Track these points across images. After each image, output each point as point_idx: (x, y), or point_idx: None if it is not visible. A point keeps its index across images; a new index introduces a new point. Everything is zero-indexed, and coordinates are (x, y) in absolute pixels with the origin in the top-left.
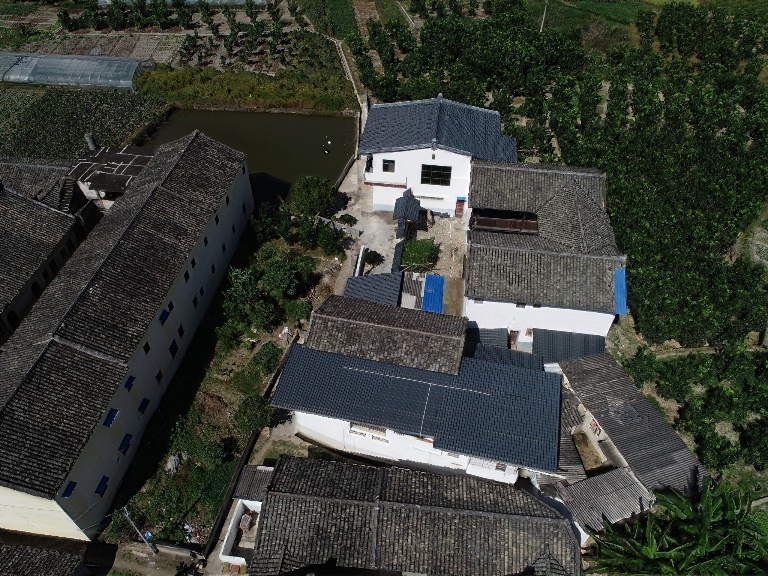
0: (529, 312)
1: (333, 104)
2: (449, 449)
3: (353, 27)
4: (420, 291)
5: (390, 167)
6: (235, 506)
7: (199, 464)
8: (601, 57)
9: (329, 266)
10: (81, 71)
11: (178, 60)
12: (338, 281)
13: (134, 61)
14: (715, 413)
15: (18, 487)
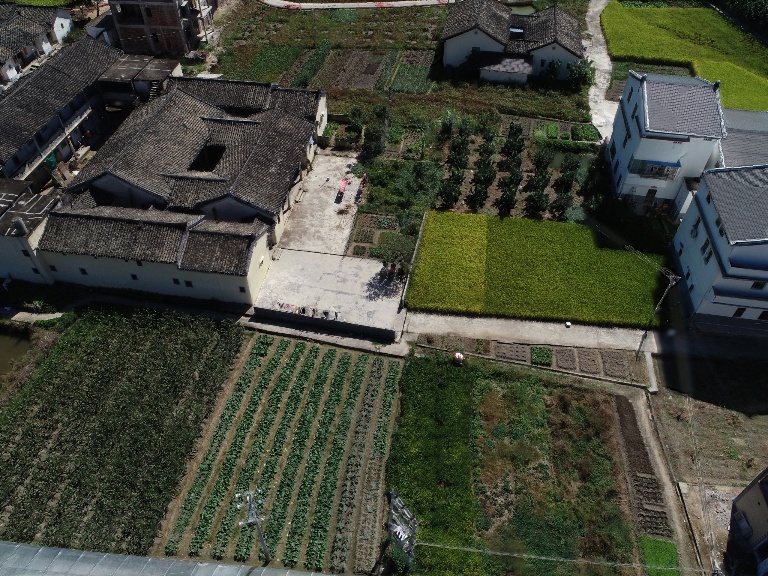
0: None
1: None
2: None
3: None
4: None
5: None
6: None
7: None
8: None
9: None
10: (74, 573)
11: None
12: None
13: None
14: None
15: None
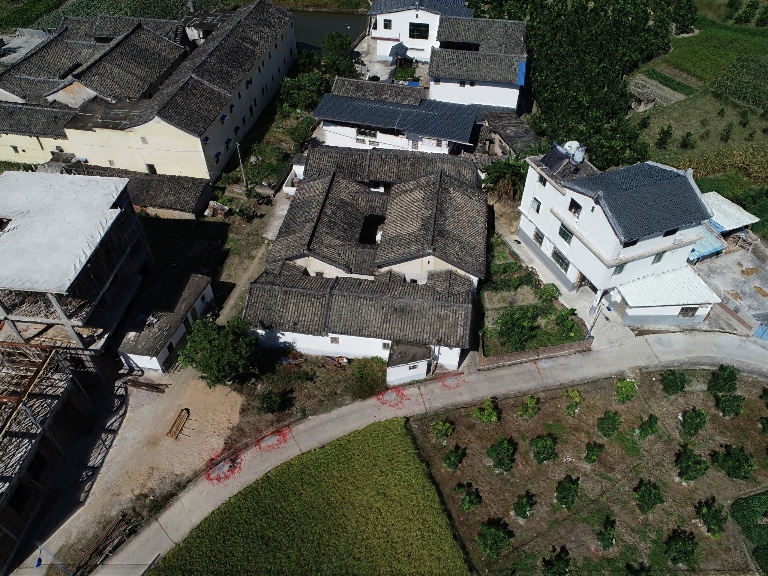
0: (468, 90)
1: (352, 5)
2: (410, 133)
3: None
4: None
5: (388, 25)
6: None
7: None
8: None
9: None
10: None
11: None
12: None
13: None
14: (571, 137)
15: (183, 128)
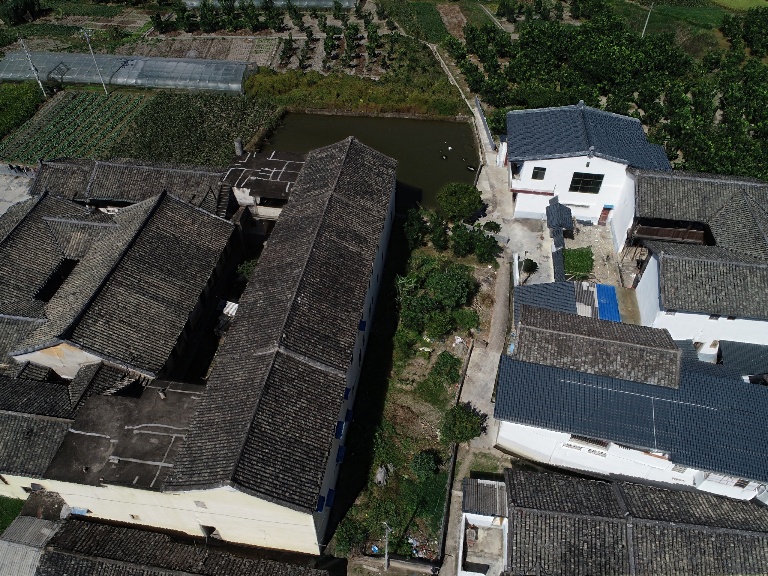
0: (721, 324)
1: (446, 109)
2: (689, 465)
3: (444, 31)
4: (594, 301)
5: (540, 174)
6: (453, 520)
7: (406, 476)
8: (700, 63)
9: (484, 274)
10: (189, 74)
11: (277, 63)
12: (497, 290)
13: (235, 64)
14: None
15: (282, 502)
